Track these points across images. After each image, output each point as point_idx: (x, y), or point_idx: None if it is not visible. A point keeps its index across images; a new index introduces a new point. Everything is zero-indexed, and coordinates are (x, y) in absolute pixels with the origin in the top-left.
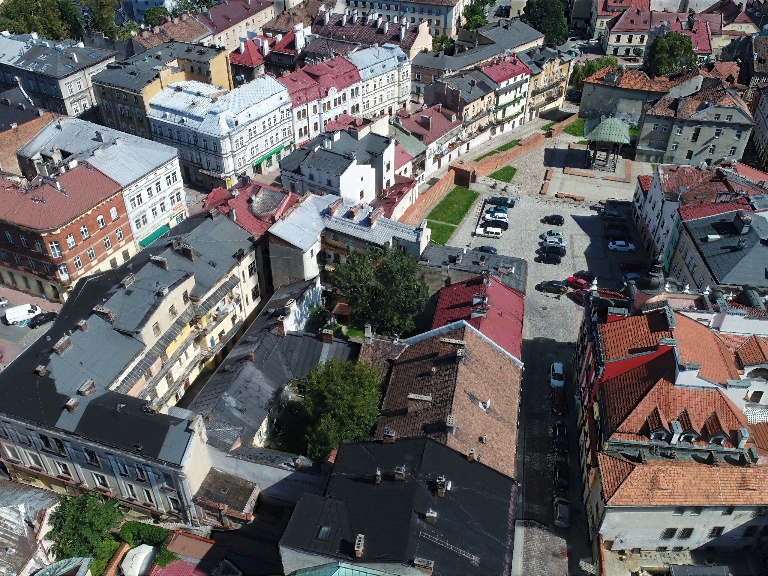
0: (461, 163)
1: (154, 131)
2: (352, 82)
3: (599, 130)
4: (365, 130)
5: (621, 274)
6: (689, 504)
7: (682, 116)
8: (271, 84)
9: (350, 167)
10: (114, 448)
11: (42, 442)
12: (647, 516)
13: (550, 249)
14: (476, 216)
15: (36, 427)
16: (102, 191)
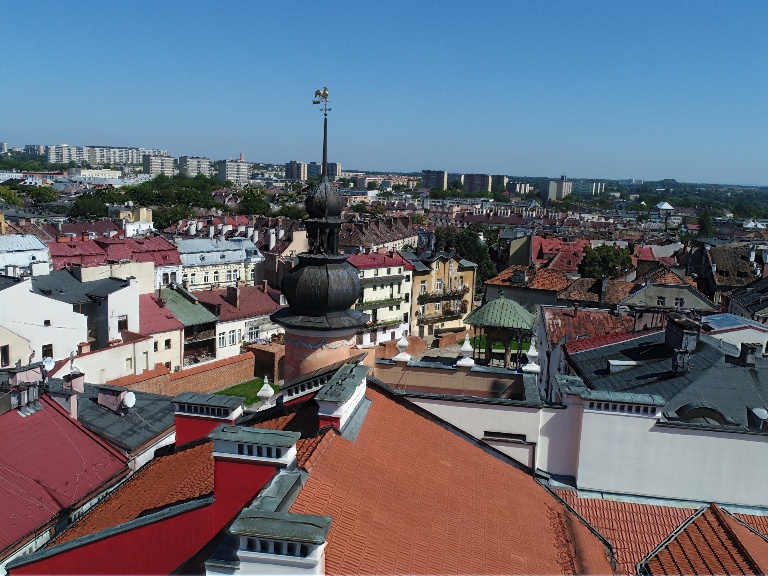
0: (267, 344)
1: None
2: (165, 264)
3: (485, 312)
4: (99, 271)
5: None
6: None
7: (609, 300)
8: (28, 242)
9: (10, 290)
10: None
11: None
12: None
13: None
14: None
15: None
16: None
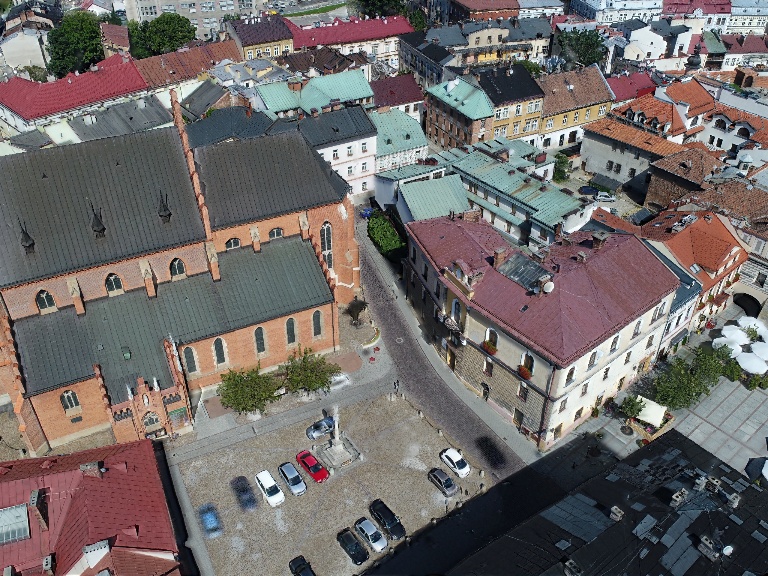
0: (745, 69)
1: (571, 6)
2: (721, 12)
3: None
4: (679, 21)
5: None
6: (616, 139)
7: None
8: None
9: (643, 29)
10: (429, 57)
11: (411, 59)
12: (600, 146)
13: None
14: None
15: (411, 46)
16: (509, 5)
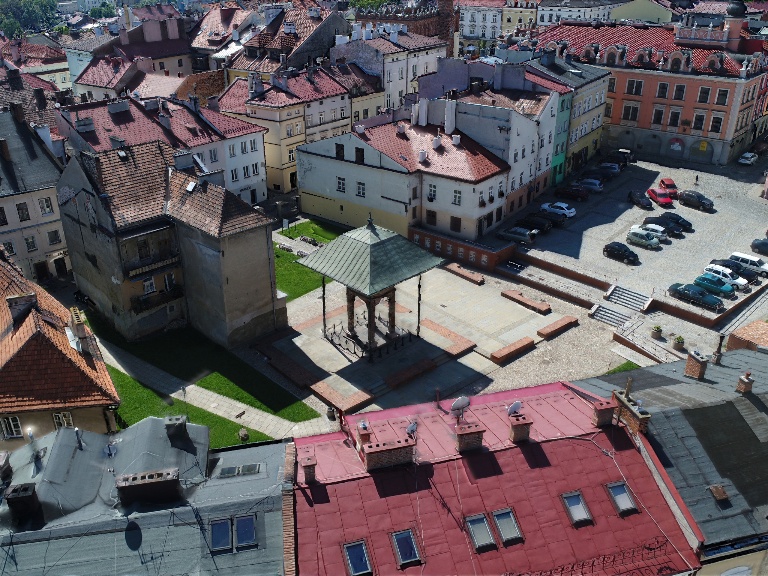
0: None
1: None
2: None
3: None
4: None
5: (593, 198)
6: None
7: None
8: None
9: None
10: None
11: None
12: None
13: (670, 222)
14: (759, 305)
15: None
16: None
